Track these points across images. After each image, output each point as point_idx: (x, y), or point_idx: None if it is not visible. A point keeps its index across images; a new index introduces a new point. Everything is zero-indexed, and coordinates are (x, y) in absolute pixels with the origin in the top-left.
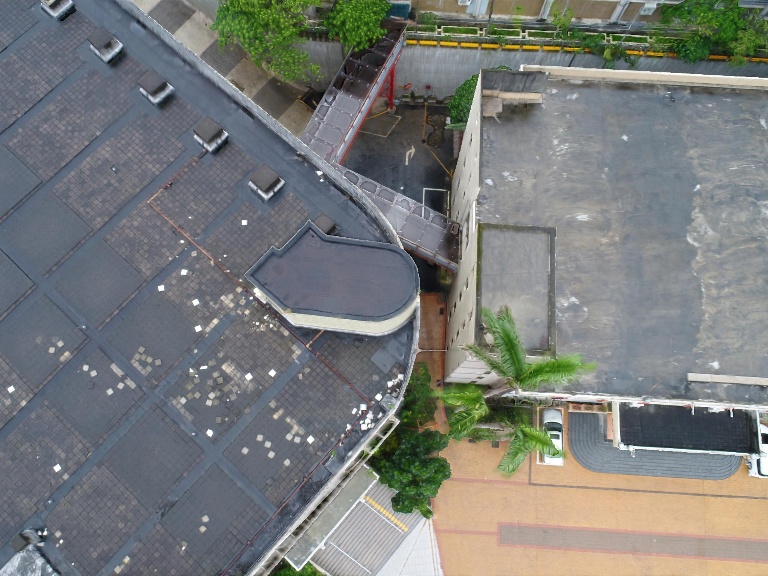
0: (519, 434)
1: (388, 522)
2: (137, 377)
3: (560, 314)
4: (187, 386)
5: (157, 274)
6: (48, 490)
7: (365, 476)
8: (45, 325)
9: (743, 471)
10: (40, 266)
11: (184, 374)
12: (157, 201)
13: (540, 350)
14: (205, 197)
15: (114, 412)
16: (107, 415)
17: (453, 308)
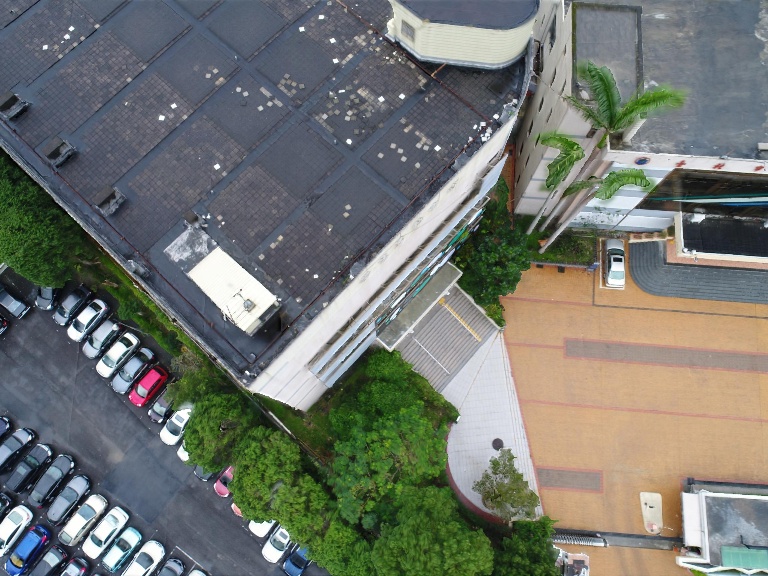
0: (612, 172)
1: None
2: (283, 98)
3: None
4: (328, 105)
5: (297, 19)
6: (210, 184)
7: (449, 272)
8: (201, 57)
9: None
10: (195, 11)
11: (325, 96)
12: None
13: None
14: None
15: (265, 124)
16: (259, 127)
17: (528, 132)
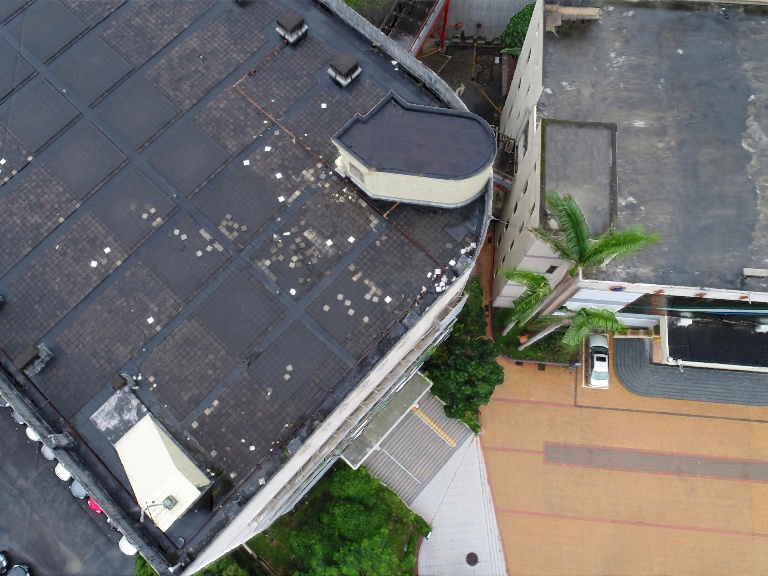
0: (582, 312)
1: (438, 435)
2: (224, 241)
3: (618, 212)
4: (271, 250)
5: (242, 150)
6: (142, 340)
7: (419, 383)
8: (138, 194)
9: None
10: (133, 142)
11: (268, 239)
12: (242, 86)
13: (602, 235)
14: (286, 83)
15: (203, 272)
16: (197, 274)
17: (504, 228)
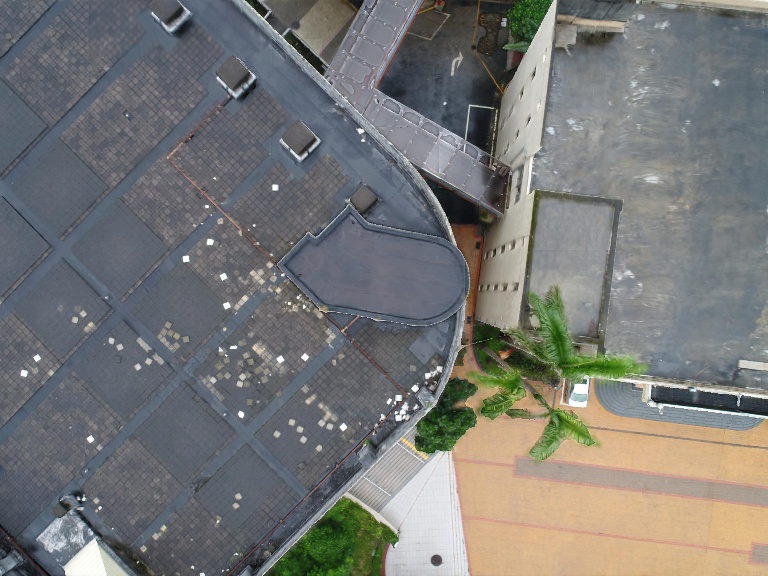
0: (555, 420)
1: (409, 452)
2: (165, 353)
3: (612, 288)
4: (217, 366)
5: (181, 242)
6: (83, 459)
7: None
8: (66, 293)
9: (767, 423)
10: (54, 227)
11: (213, 353)
12: (177, 157)
13: (588, 337)
14: (231, 154)
15: (143, 388)
16: (136, 390)
17: (492, 251)
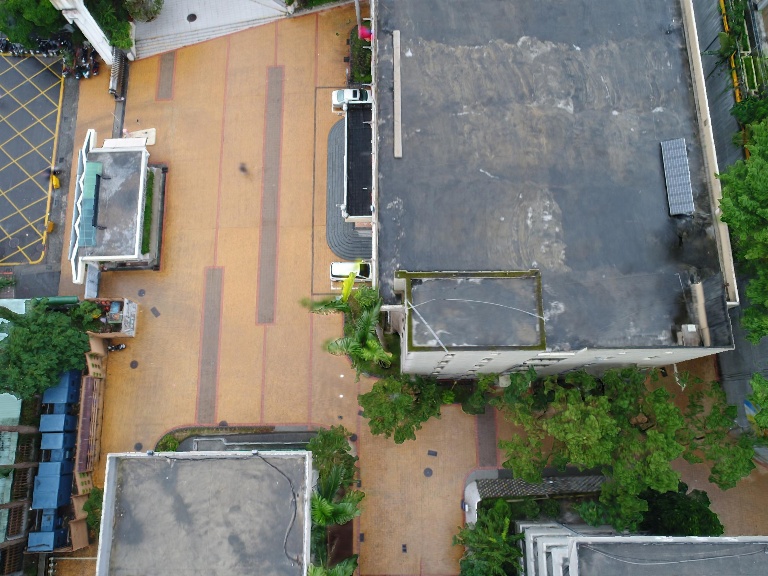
0: None
1: None
2: None
3: None
4: None
5: None
6: None
7: None
8: None
9: (335, 260)
10: None
11: None
12: None
13: None
14: None
15: None
16: None
17: None
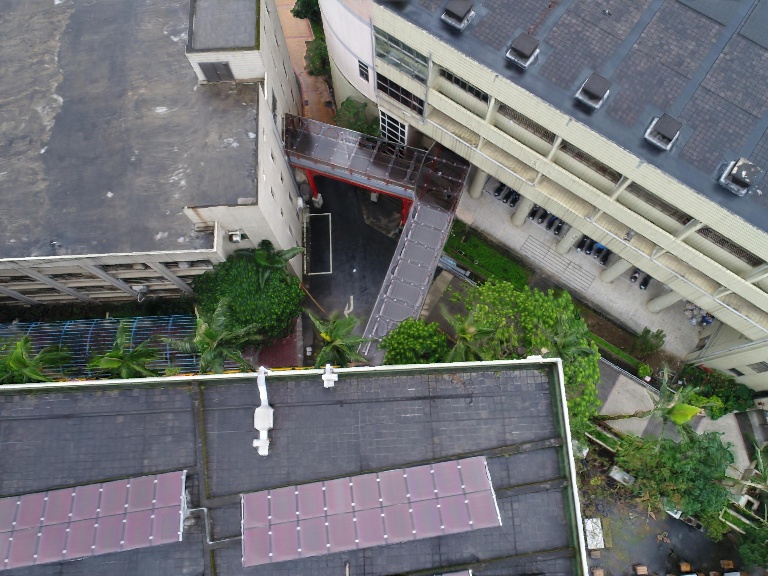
0: None
1: None
2: None
3: None
4: None
5: None
6: None
7: None
8: None
9: None
10: None
11: None
12: None
13: None
14: None
15: None
16: None
17: None
